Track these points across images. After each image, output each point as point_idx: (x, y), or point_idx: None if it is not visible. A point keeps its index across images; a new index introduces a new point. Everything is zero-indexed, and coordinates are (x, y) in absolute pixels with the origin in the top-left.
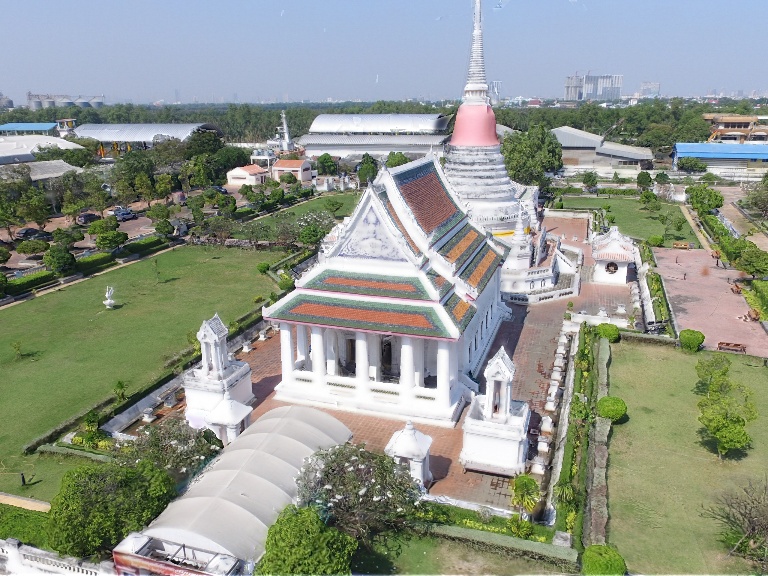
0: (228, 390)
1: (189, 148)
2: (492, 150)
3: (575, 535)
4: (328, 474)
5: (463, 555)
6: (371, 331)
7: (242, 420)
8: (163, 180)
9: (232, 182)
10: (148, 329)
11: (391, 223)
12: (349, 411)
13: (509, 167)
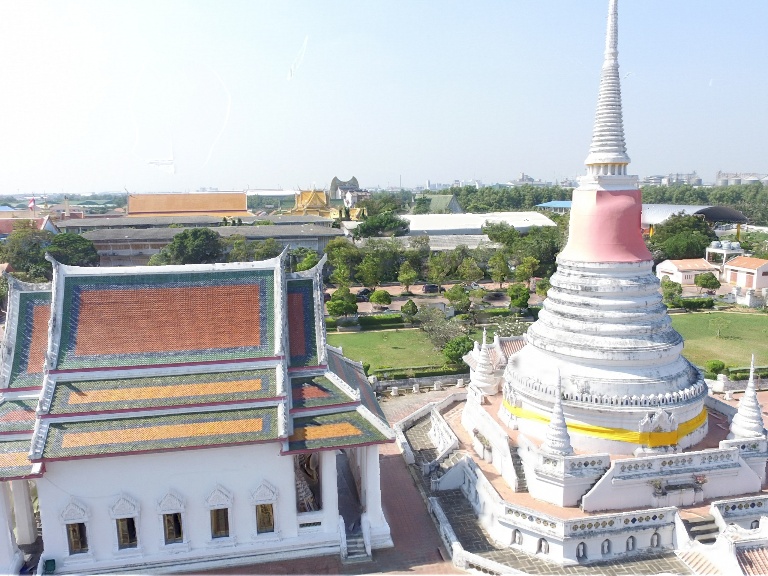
0: None
1: (659, 233)
2: (598, 270)
3: None
4: None
5: None
6: None
7: None
8: (525, 263)
9: (660, 276)
10: None
11: (7, 328)
12: None
13: None
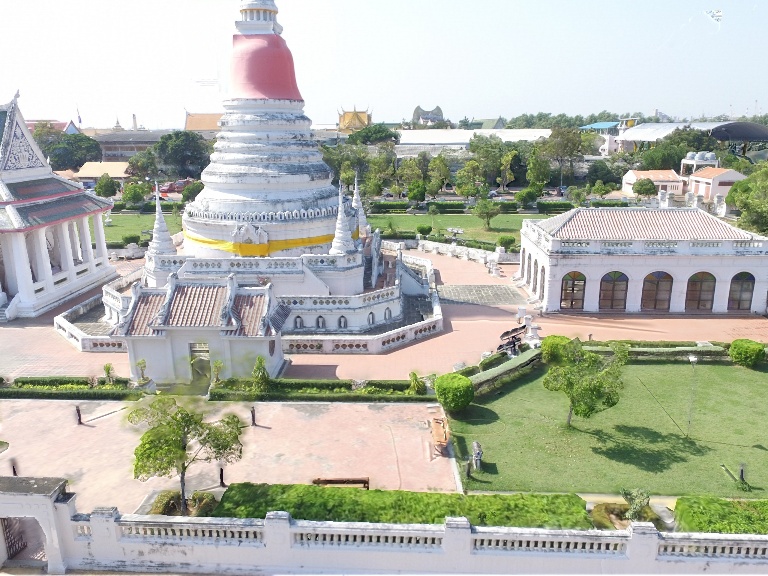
0: None
1: None
2: (234, 107)
3: None
4: None
5: None
6: None
7: None
8: (466, 167)
9: (625, 188)
10: None
11: None
12: None
13: (760, 187)
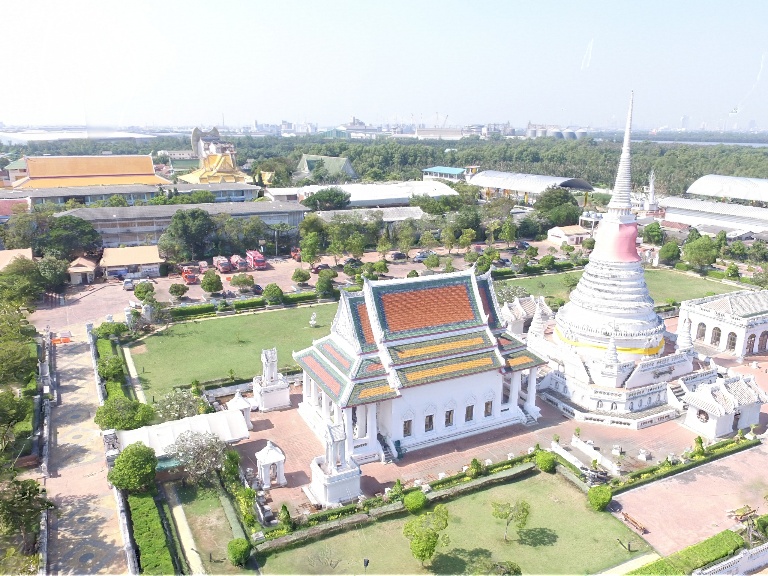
0: (262, 393)
1: (539, 202)
2: (619, 266)
3: (266, 538)
4: (182, 441)
5: (221, 516)
6: (318, 385)
7: (243, 411)
8: (466, 234)
9: (551, 239)
10: (308, 346)
11: (349, 319)
12: (315, 433)
13: None
